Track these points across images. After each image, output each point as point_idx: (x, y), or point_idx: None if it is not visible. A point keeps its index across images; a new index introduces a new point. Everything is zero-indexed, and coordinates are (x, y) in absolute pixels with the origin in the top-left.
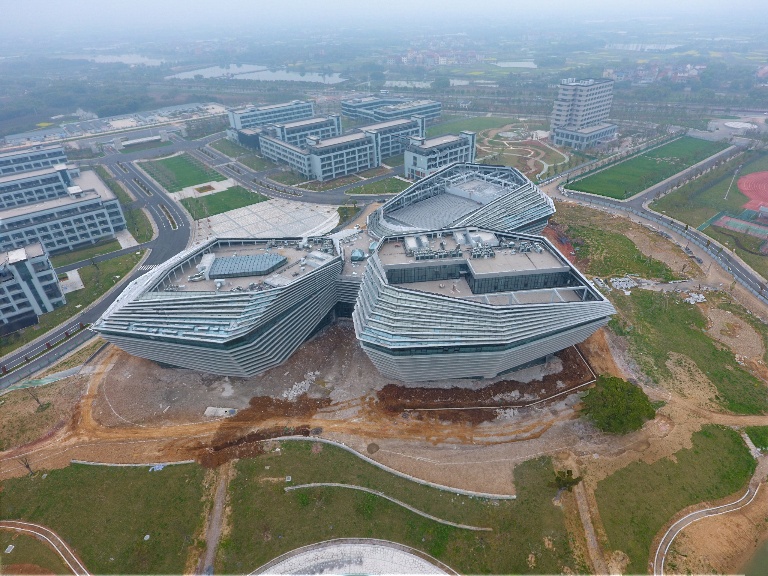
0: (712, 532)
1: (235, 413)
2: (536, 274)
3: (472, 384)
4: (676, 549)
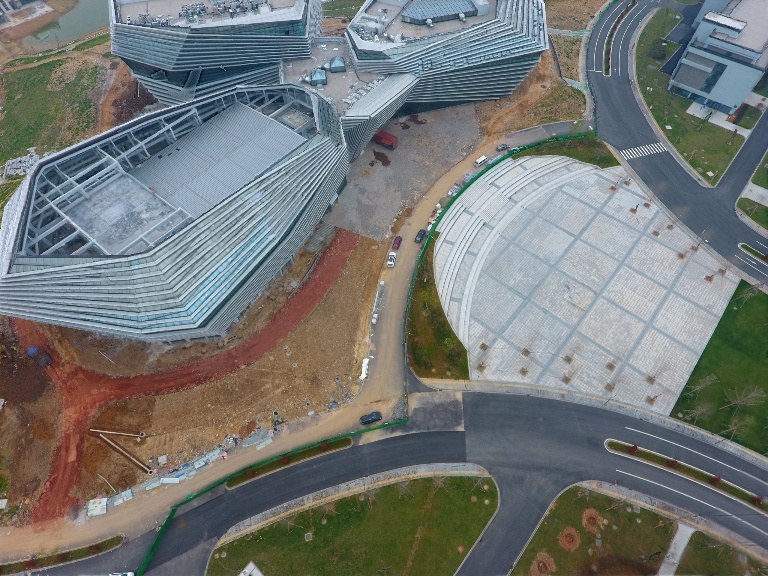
0: None
1: None
2: None
3: None
4: None
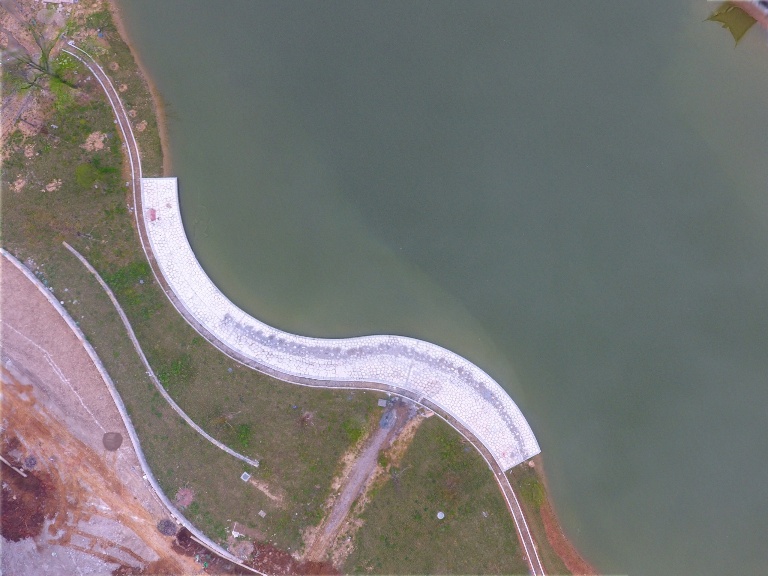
0: None
1: None
2: None
3: None
4: None
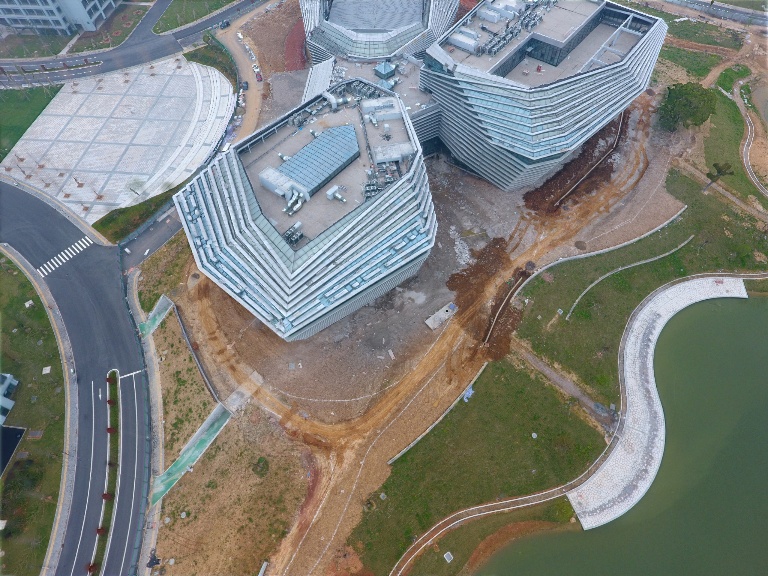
0: (760, 155)
1: (455, 306)
2: (590, 21)
3: (571, 154)
4: (759, 176)
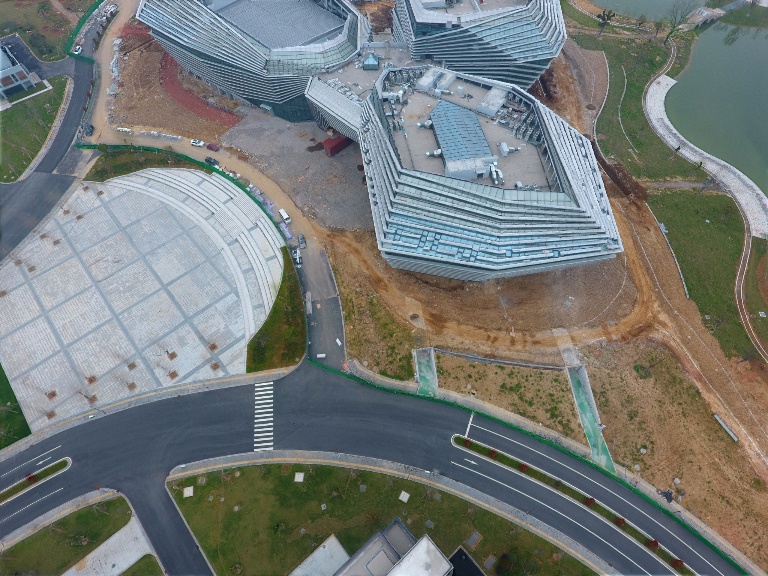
0: (586, 6)
1: None
2: None
3: None
4: None
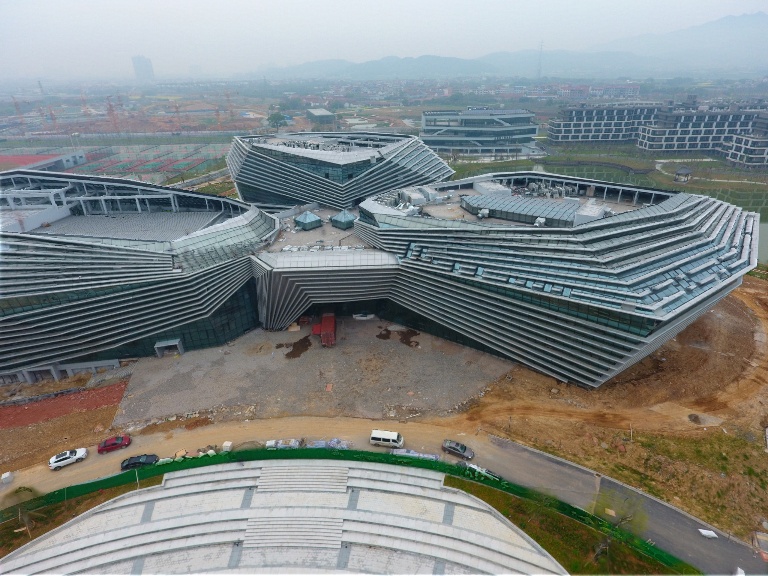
0: None
1: None
2: None
3: None
4: None
